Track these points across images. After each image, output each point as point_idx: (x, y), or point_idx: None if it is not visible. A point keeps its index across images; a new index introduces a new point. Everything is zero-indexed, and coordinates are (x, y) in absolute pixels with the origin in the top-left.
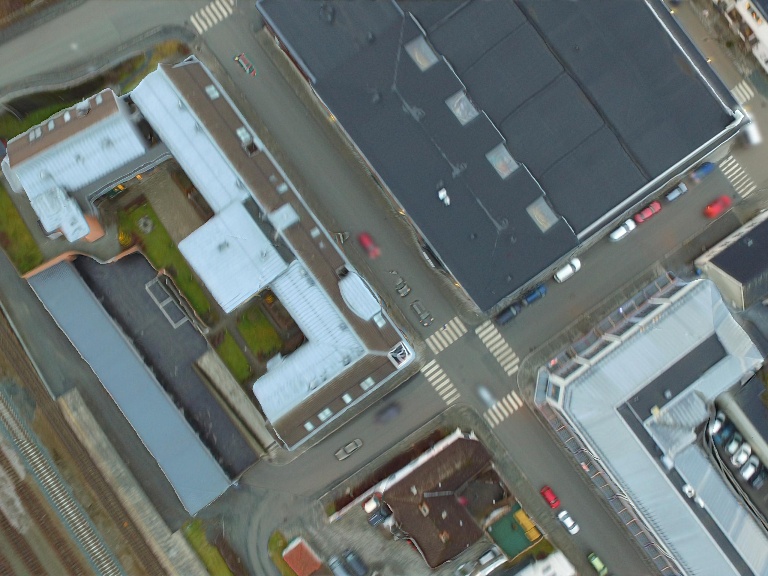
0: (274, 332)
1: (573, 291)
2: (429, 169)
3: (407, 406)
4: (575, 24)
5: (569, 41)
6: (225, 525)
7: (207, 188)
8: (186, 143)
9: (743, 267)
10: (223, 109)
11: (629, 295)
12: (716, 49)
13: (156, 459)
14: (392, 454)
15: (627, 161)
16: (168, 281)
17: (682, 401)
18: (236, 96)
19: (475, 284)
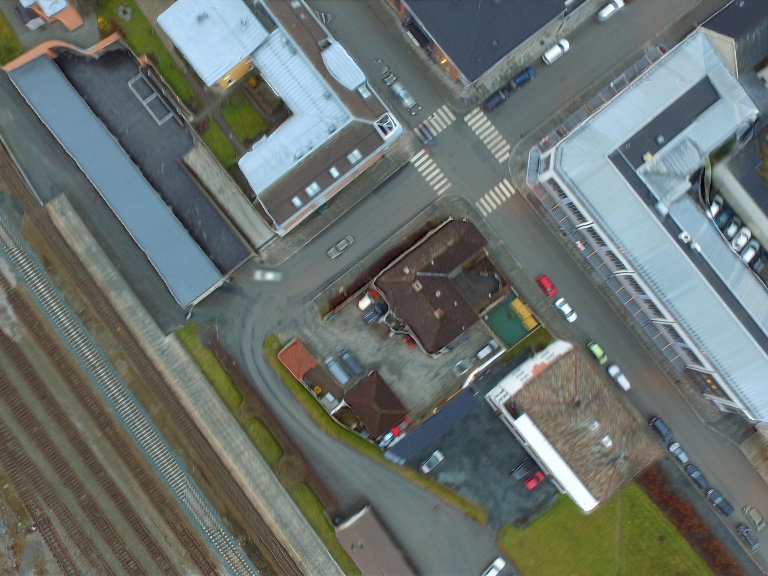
0: (259, 117)
1: (563, 74)
2: None
3: (398, 199)
4: None
5: None
6: (219, 328)
7: None
8: None
9: (735, 24)
10: None
11: None
12: None
13: (145, 251)
14: (384, 249)
15: None
16: (150, 72)
17: (675, 149)
18: None
19: (460, 52)
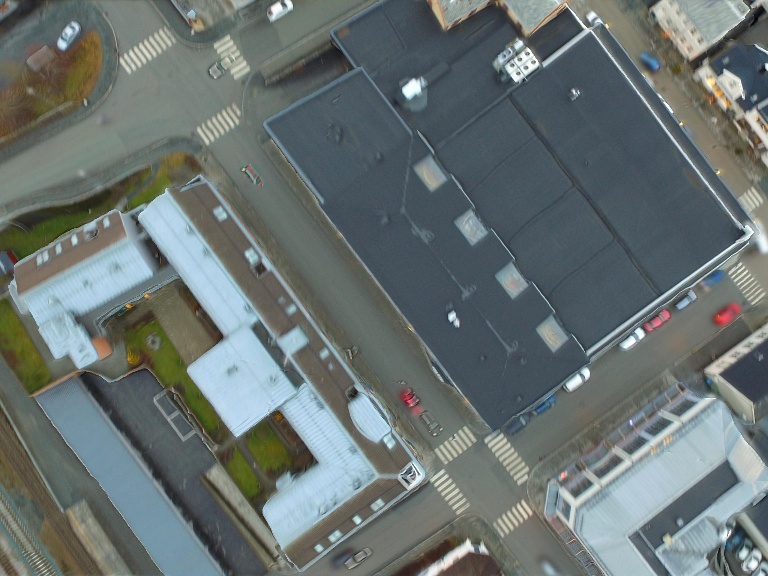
0: (283, 448)
1: (582, 400)
2: (438, 291)
3: (416, 515)
4: (584, 139)
5: (578, 156)
6: None
7: (215, 311)
8: (194, 266)
9: (754, 384)
10: (231, 231)
11: (639, 404)
12: (725, 156)
13: None
14: (402, 563)
15: (637, 276)
16: (176, 397)
17: (694, 527)
18: (243, 208)
19: (485, 404)
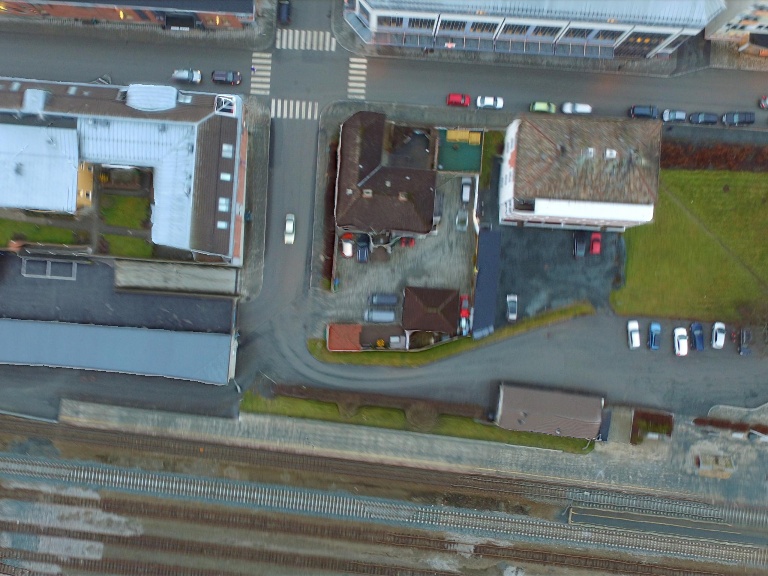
0: (135, 199)
1: None
2: None
3: (292, 153)
4: None
5: None
6: (268, 376)
7: None
8: None
9: None
10: None
11: None
12: None
13: (159, 375)
14: (321, 198)
15: None
16: (28, 250)
17: None
18: None
19: None
